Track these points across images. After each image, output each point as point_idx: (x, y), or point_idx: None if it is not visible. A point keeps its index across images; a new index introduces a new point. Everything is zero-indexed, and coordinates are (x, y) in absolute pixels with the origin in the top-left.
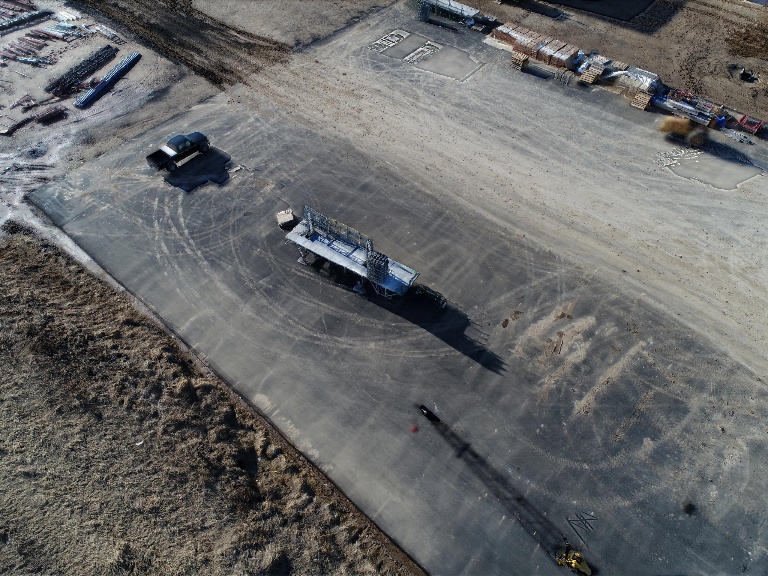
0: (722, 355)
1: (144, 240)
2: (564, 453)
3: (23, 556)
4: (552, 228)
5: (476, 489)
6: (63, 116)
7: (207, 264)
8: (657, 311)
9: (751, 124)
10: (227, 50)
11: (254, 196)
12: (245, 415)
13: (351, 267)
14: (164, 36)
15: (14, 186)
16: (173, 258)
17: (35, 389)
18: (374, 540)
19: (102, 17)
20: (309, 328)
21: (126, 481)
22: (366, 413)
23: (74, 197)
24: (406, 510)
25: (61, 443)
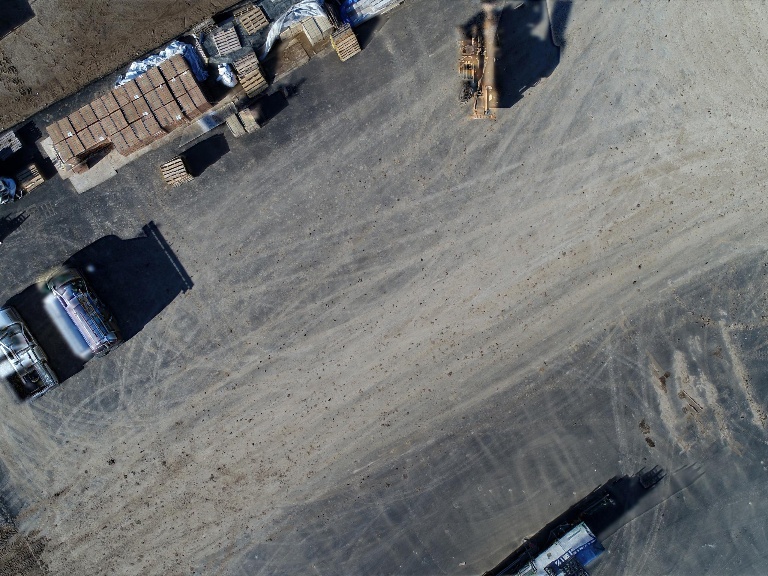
0: (763, 256)
1: None
2: None
3: None
4: (545, 324)
5: None
6: None
7: None
8: (695, 283)
9: None
10: None
11: None
12: None
13: None
14: None
15: None
16: None
17: None
18: None
19: None
20: None
21: None
22: None
23: None
24: None
25: None
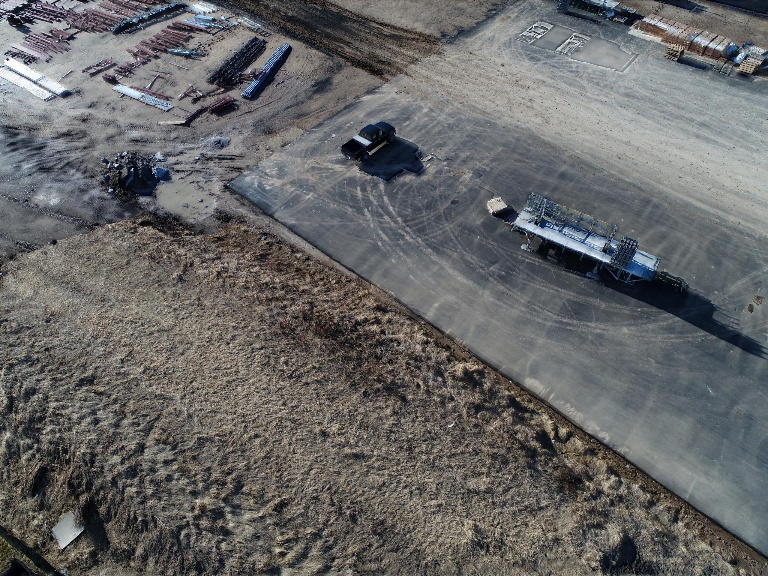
0: None
1: (360, 228)
2: None
3: (378, 536)
4: (764, 215)
5: None
6: (235, 107)
7: (432, 251)
8: None
9: None
10: (375, 42)
11: (455, 185)
12: (522, 399)
13: (590, 253)
14: (307, 28)
15: (210, 175)
16: (396, 245)
17: (334, 372)
18: (695, 520)
19: (238, 10)
20: (556, 313)
21: (452, 462)
22: (643, 396)
23: (275, 186)
24: (716, 491)
25: (378, 425)
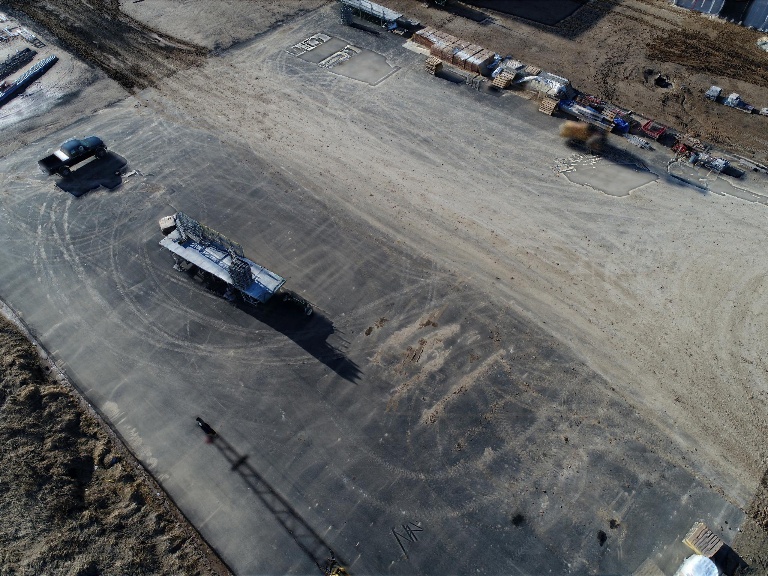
0: (580, 364)
1: (24, 245)
2: (403, 463)
3: None
4: (434, 235)
5: (308, 499)
6: None
7: (82, 270)
8: (523, 319)
9: (656, 130)
10: (145, 53)
11: (143, 201)
12: (91, 423)
13: (218, 274)
14: (85, 39)
15: None
16: (49, 264)
17: None
18: (195, 550)
19: (27, 20)
20: (172, 335)
21: None
22: (212, 421)
23: None
24: (233, 520)
25: None
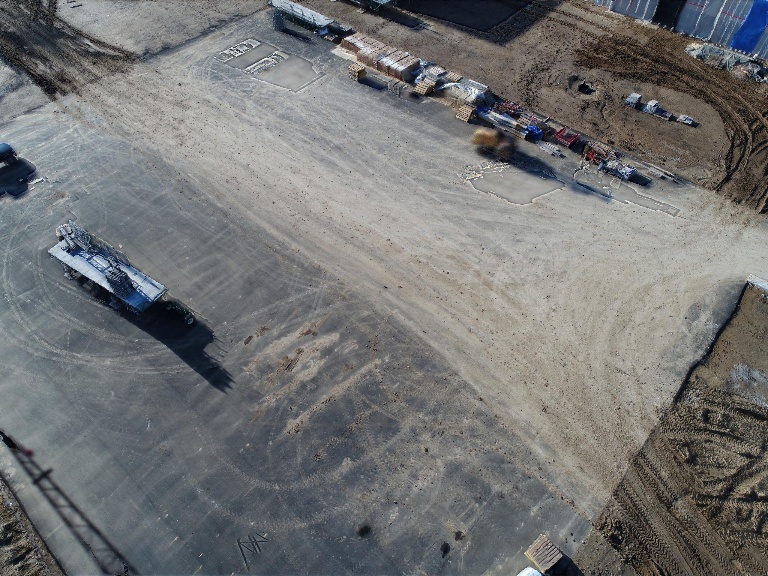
0: (452, 374)
1: None
2: (259, 473)
3: None
4: (329, 243)
5: (159, 509)
6: None
7: None
8: (404, 328)
9: (570, 137)
10: (73, 59)
11: (45, 208)
12: None
13: (102, 282)
14: (16, 45)
15: None
16: None
17: None
18: (38, 561)
19: None
20: (51, 344)
21: None
22: (77, 431)
23: None
24: (81, 530)
25: None
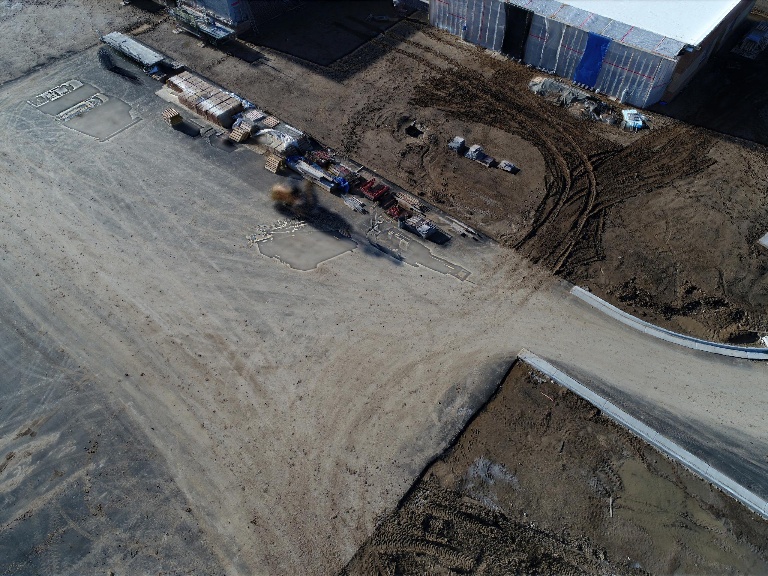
0: (167, 479)
1: None
2: None
3: None
4: (83, 322)
5: None
6: None
7: None
8: (131, 425)
9: None
10: None
11: None
12: None
13: None
14: None
15: None
16: None
17: None
18: None
19: None
20: None
21: None
22: None
23: None
24: None
25: None
